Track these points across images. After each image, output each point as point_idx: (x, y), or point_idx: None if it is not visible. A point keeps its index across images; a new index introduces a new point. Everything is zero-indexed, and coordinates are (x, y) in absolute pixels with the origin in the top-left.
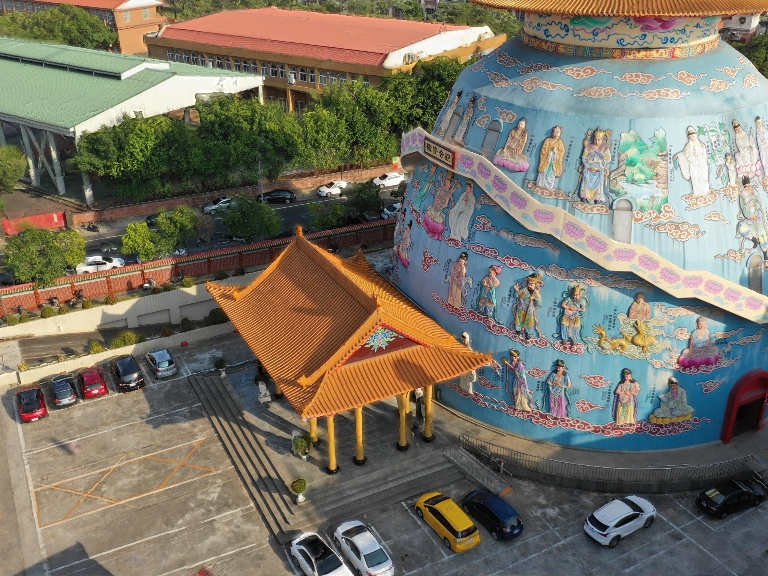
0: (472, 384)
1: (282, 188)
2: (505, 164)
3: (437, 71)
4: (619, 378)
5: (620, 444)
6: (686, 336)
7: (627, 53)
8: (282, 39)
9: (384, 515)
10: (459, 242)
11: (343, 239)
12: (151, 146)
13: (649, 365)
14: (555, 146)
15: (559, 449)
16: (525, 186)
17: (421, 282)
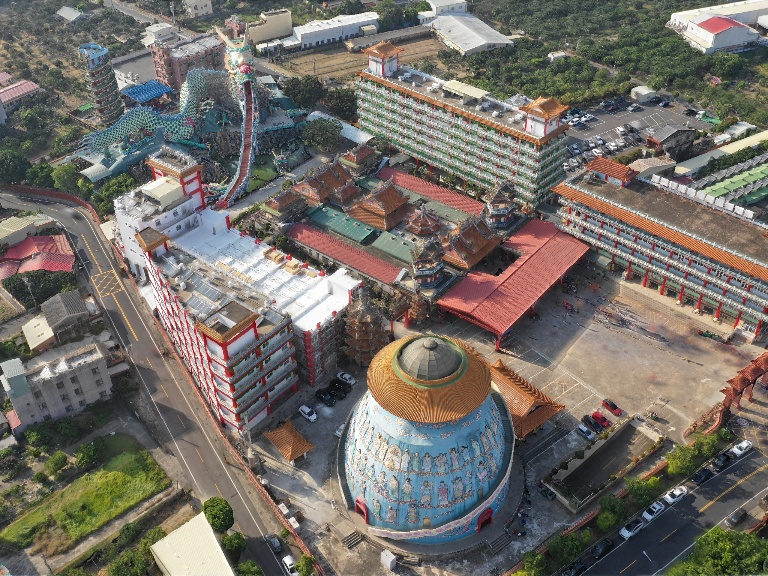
0: None
1: None
2: None
3: None
4: None
5: None
6: None
7: None
8: None
9: None
10: None
11: None
12: None
13: None
14: None
15: None
16: None
17: None
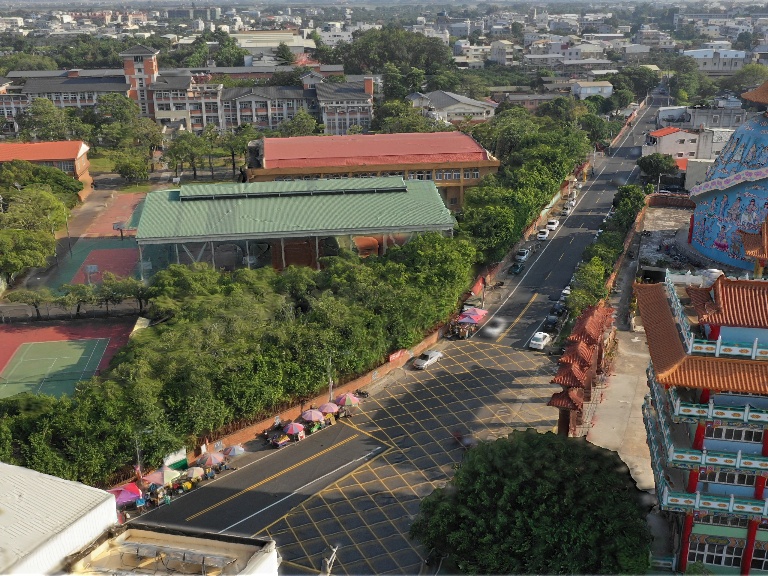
0: None
1: None
2: None
3: (552, 155)
4: None
5: None
6: None
7: None
8: (390, 154)
9: None
10: None
11: None
12: None
13: None
14: None
15: None
16: None
17: None
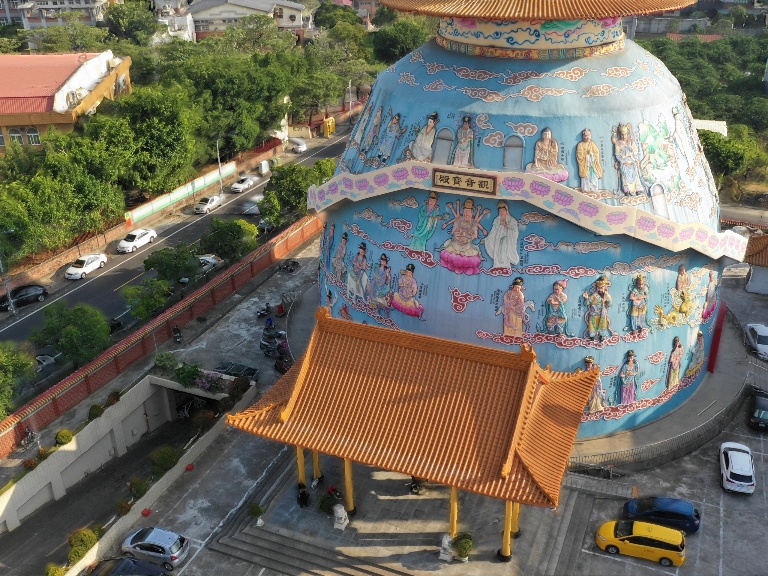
0: None
1: (18, 284)
2: None
3: (150, 106)
4: (671, 348)
5: (668, 407)
6: (706, 291)
7: (595, 50)
8: None
9: (586, 571)
10: (509, 269)
11: (179, 318)
12: None
13: (688, 327)
14: (590, 149)
15: (631, 434)
16: None
17: (453, 325)
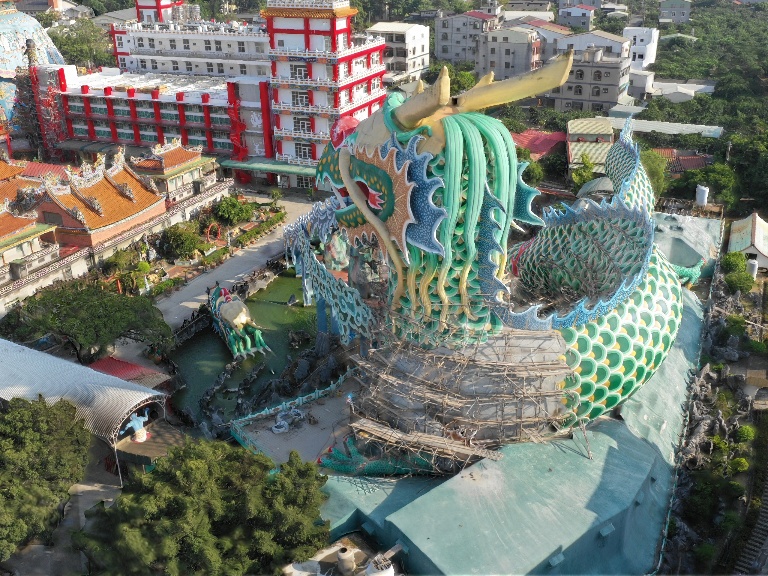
0: None
1: None
2: None
3: None
4: None
5: None
6: (14, 92)
7: None
8: None
9: None
10: None
11: None
12: None
13: (6, 102)
14: None
15: None
16: None
17: None
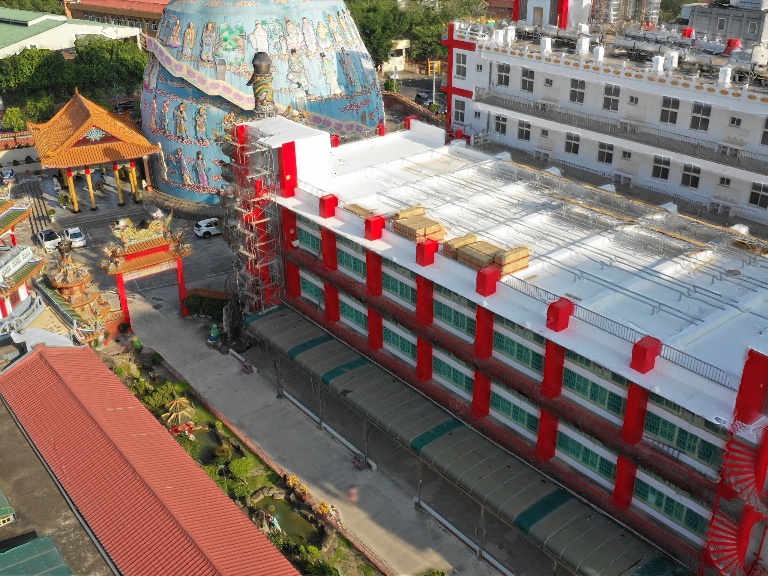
0: (166, 174)
1: None
2: (171, 44)
3: None
4: (230, 160)
5: None
6: None
7: None
8: (161, 2)
9: (97, 229)
10: (153, 90)
11: None
12: (35, 65)
13: None
14: (190, 32)
15: None
16: (178, 55)
17: (144, 119)
